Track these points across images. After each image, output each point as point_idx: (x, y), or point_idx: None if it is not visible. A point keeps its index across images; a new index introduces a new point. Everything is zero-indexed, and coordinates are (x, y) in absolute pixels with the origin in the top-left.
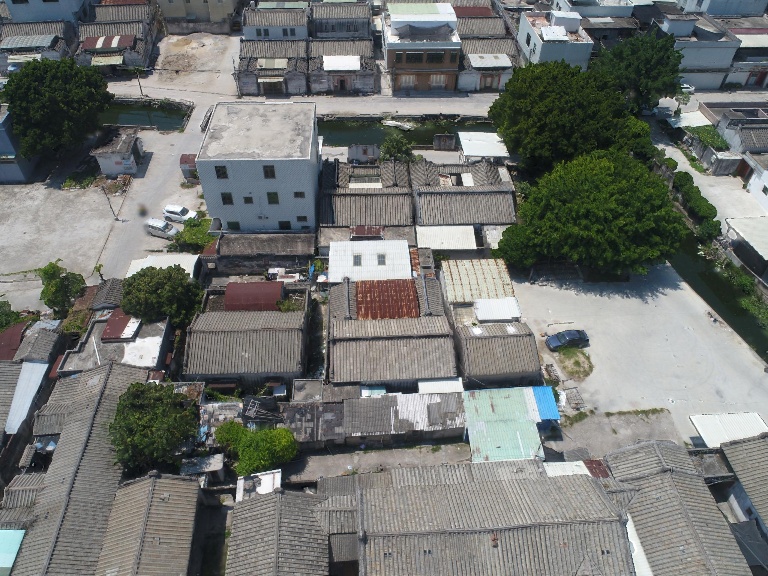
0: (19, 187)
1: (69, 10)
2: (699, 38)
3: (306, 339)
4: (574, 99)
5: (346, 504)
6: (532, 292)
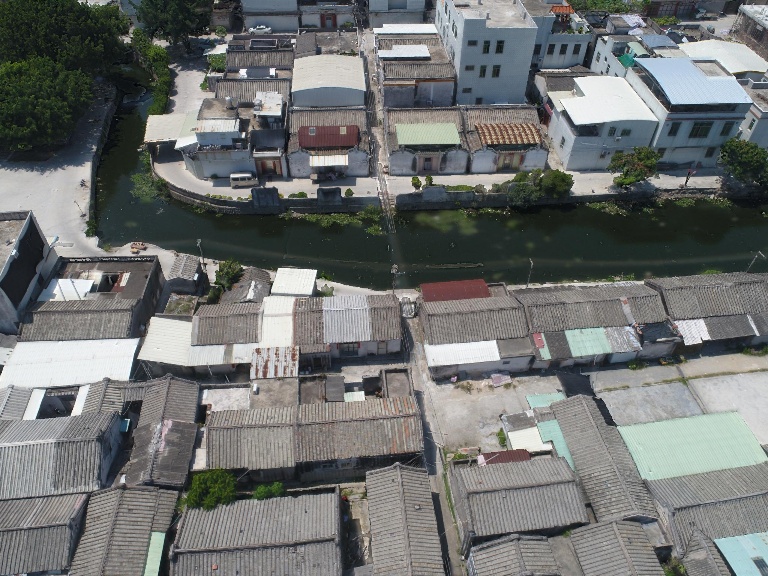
0: None
1: None
2: None
3: None
4: (21, 18)
5: None
6: None
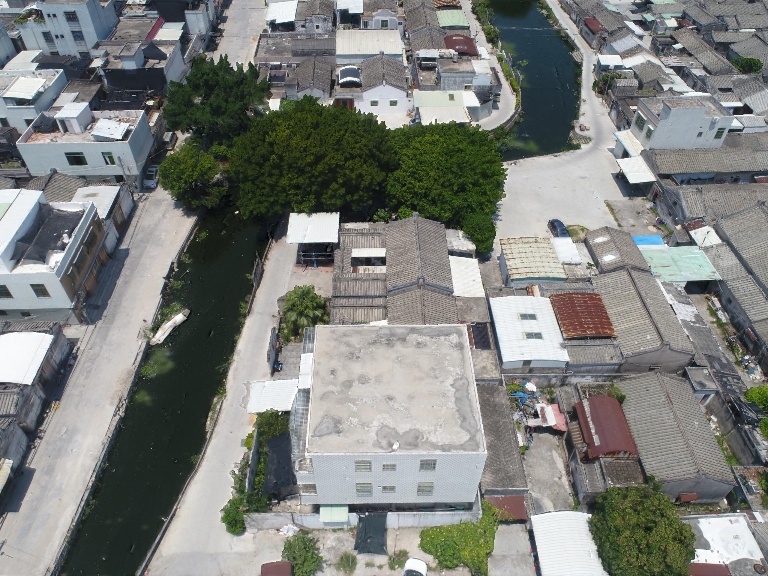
0: None
1: None
2: (152, 58)
3: None
4: None
5: None
6: None
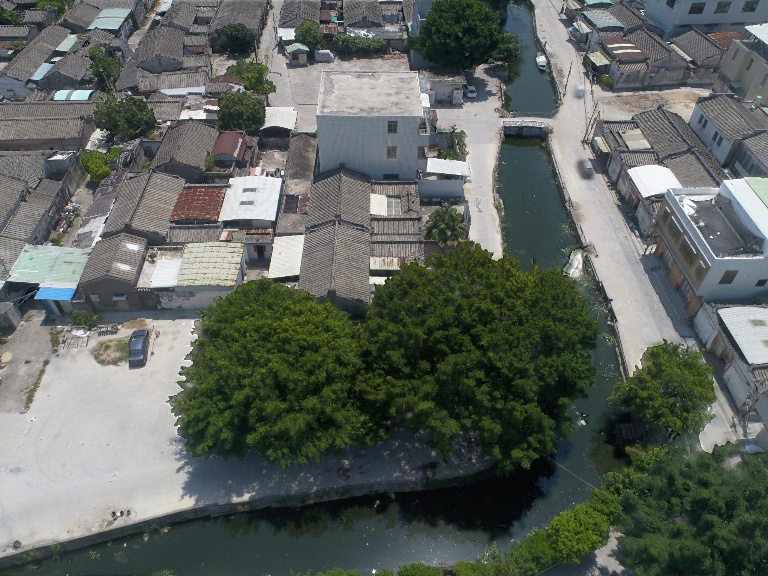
0: (406, 67)
1: (674, 20)
2: None
3: (191, 183)
4: None
5: (28, 183)
6: None
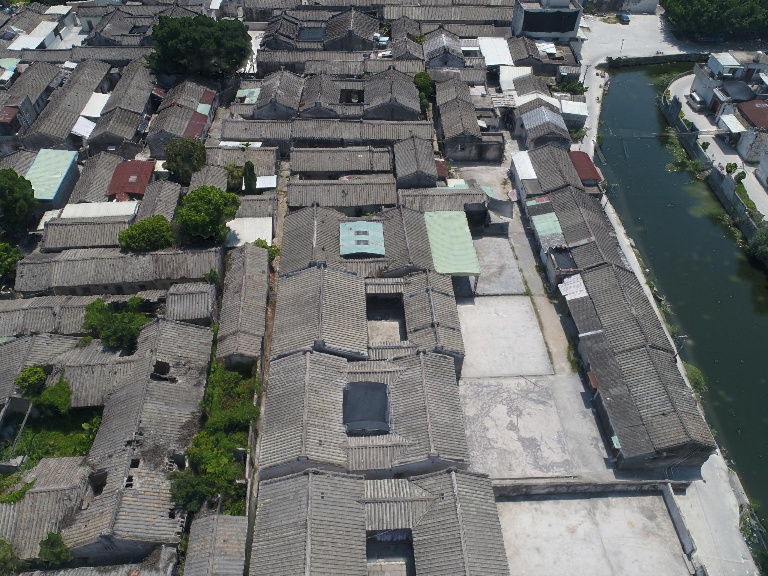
0: None
1: None
2: None
3: None
4: None
5: None
6: (654, 19)
